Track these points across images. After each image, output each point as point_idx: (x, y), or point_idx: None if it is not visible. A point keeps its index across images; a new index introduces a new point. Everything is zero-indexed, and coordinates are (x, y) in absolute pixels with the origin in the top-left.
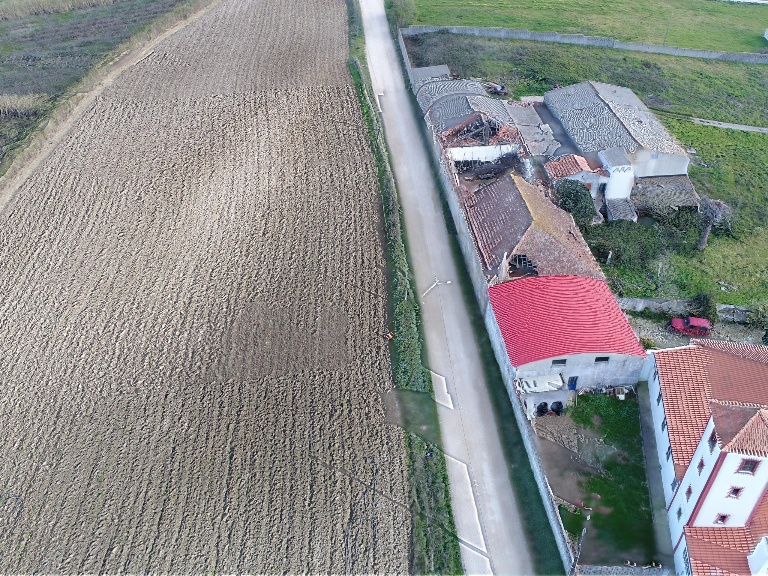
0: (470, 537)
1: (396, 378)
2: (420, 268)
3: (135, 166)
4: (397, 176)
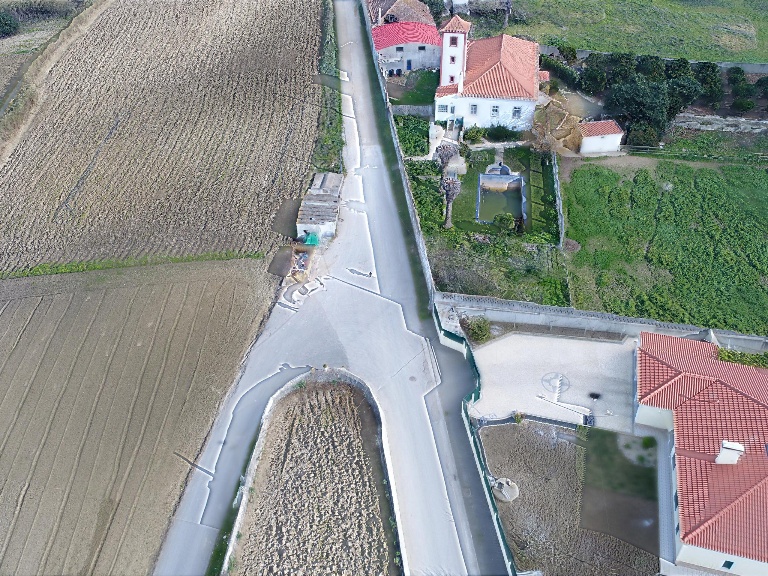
0: (348, 114)
1: (321, 70)
2: (342, 37)
3: (172, 4)
4: (335, 3)
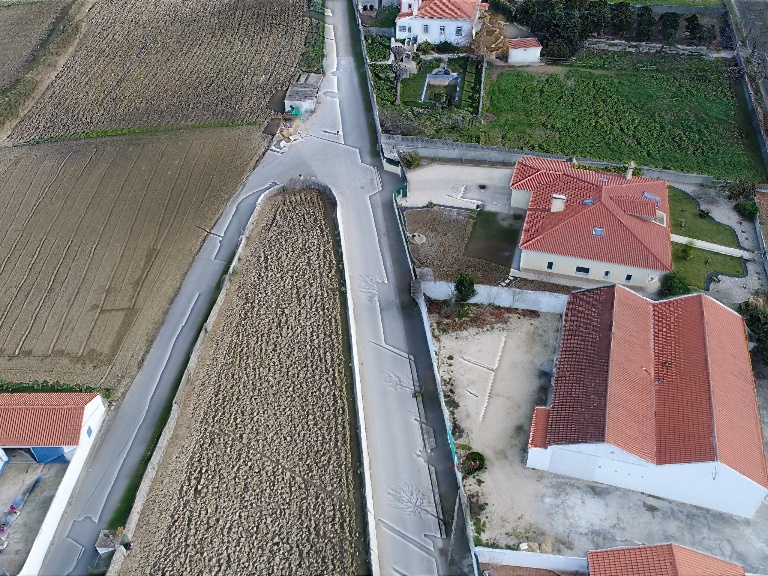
0: (330, 37)
1: (309, 7)
2: None
3: None
4: None
